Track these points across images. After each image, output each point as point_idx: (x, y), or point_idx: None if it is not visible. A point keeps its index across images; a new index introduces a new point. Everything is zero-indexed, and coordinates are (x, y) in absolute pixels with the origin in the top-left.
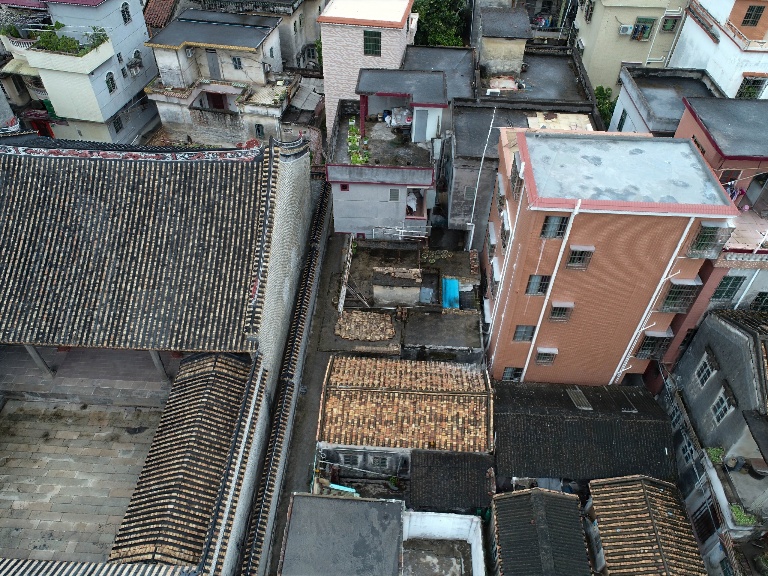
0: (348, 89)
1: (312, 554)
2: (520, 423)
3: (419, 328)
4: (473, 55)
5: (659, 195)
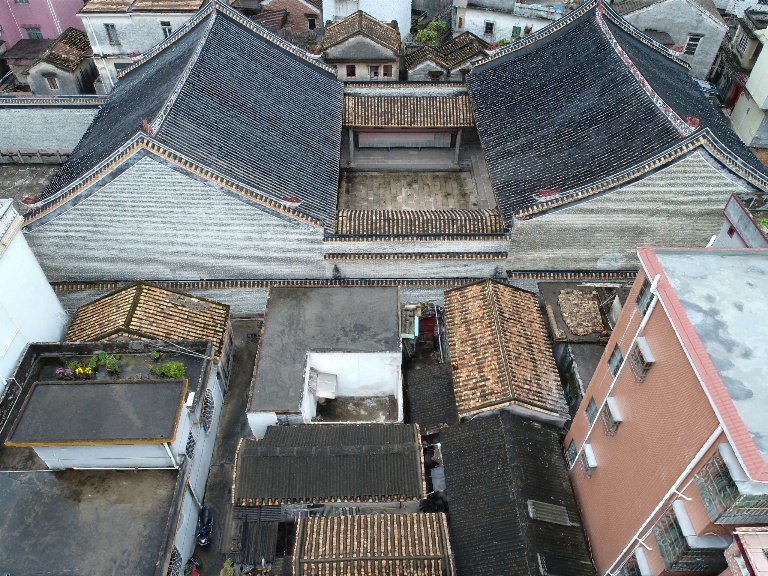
0: None
1: (354, 301)
2: (495, 439)
3: (597, 356)
4: None
5: (745, 379)
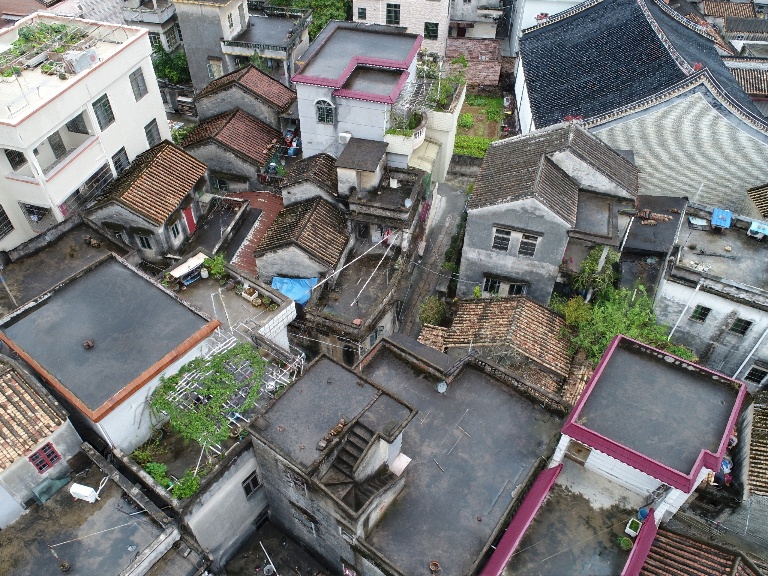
0: (446, 14)
1: None
2: None
3: None
4: None
5: None
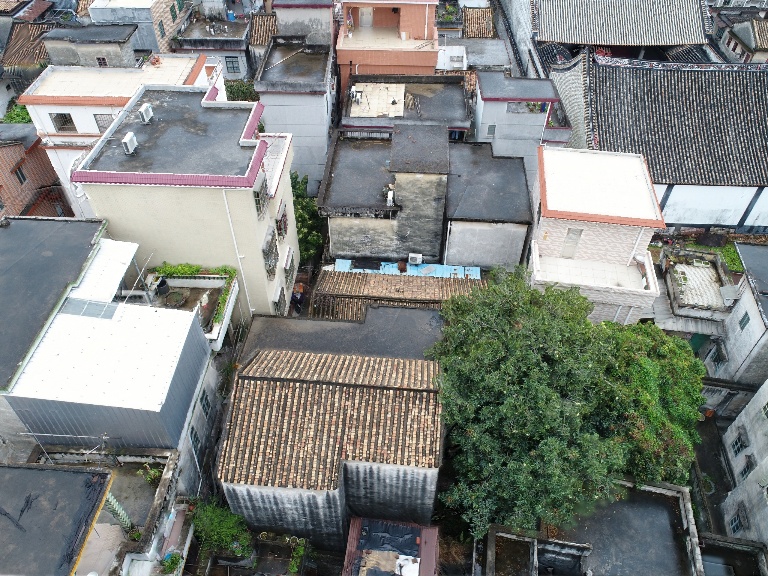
0: None
1: None
2: None
3: None
4: (447, 204)
5: None
